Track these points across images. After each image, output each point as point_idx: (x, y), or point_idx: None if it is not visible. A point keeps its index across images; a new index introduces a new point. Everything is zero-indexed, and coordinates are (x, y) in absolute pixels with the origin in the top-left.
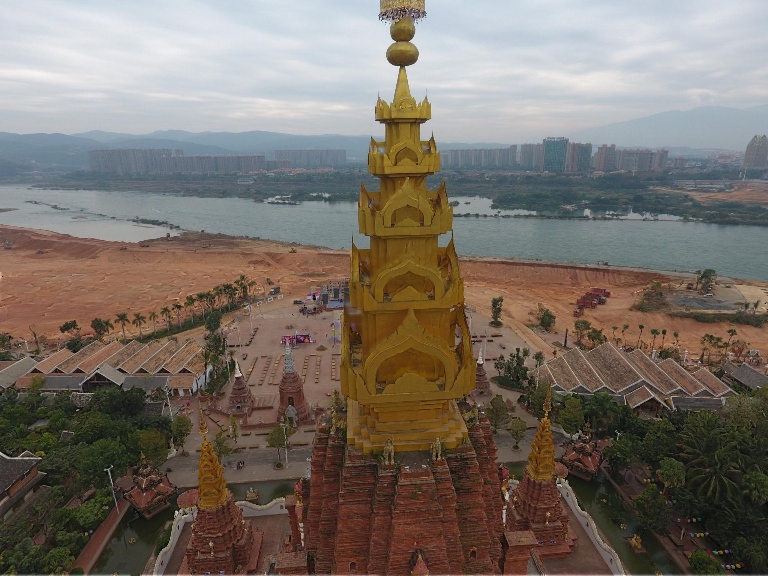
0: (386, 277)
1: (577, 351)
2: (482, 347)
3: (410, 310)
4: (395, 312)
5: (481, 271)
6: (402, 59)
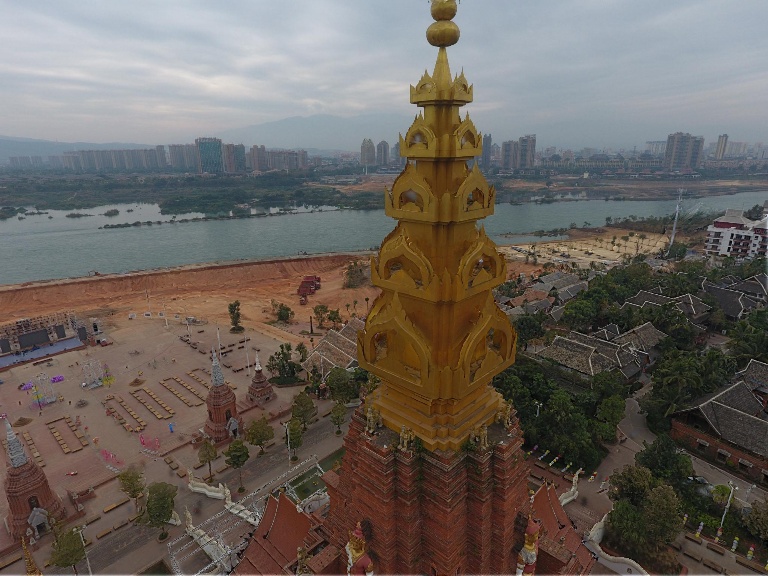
0: (470, 262)
1: (334, 332)
2: (236, 356)
3: (490, 291)
4: (471, 297)
5: (188, 281)
6: (452, 39)
